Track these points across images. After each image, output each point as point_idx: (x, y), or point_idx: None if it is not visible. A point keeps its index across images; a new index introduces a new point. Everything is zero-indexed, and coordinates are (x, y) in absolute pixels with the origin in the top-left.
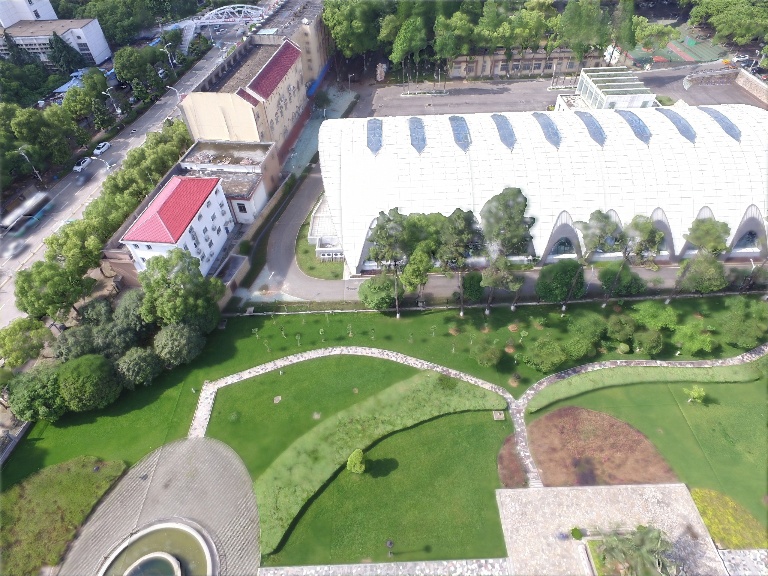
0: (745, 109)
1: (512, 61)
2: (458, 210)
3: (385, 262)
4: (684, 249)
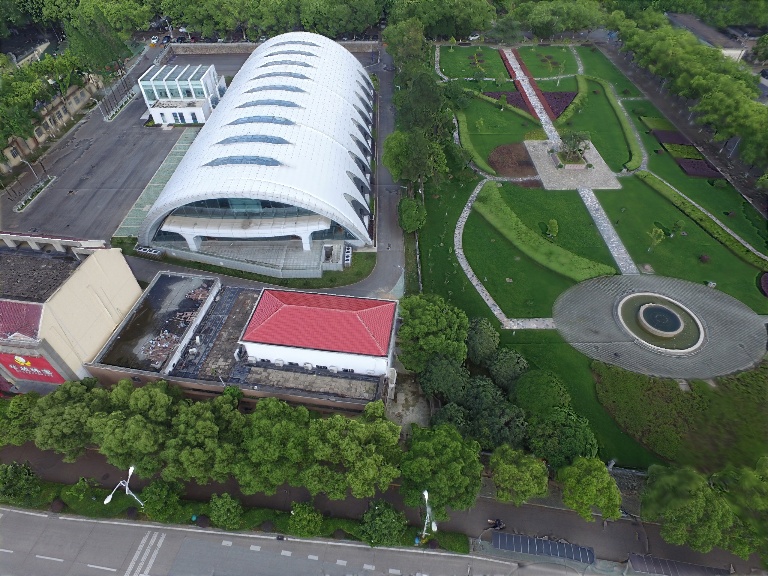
0: (286, 36)
1: None
2: (418, 109)
3: (366, 221)
4: None
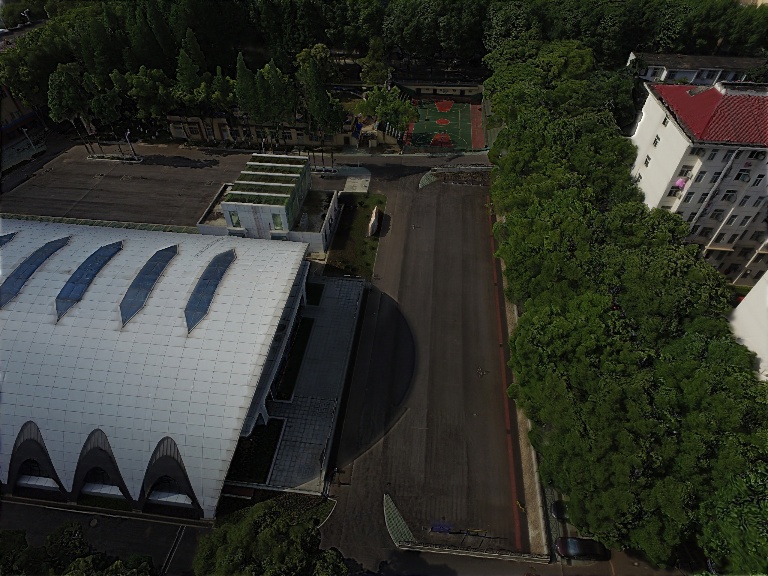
0: (273, 267)
1: (240, 126)
2: None
3: None
4: (76, 485)
